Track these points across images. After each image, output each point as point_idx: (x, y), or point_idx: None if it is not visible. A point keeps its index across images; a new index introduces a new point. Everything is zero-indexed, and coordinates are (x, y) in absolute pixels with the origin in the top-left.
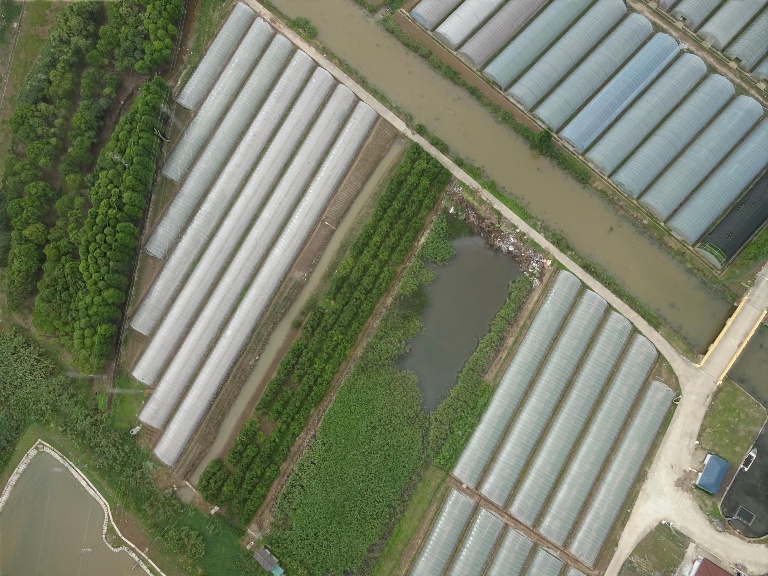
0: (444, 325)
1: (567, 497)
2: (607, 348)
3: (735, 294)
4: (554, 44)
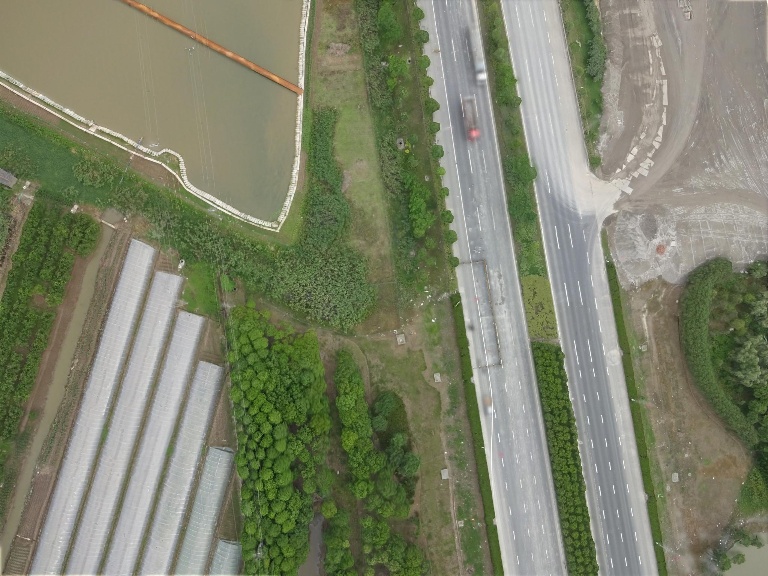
0: None
1: None
2: None
3: None
4: None
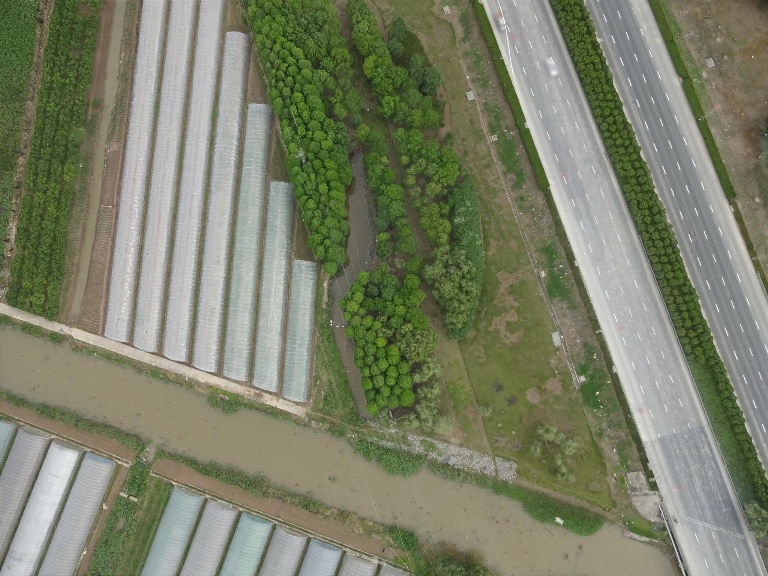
0: None
1: None
2: None
3: None
4: None
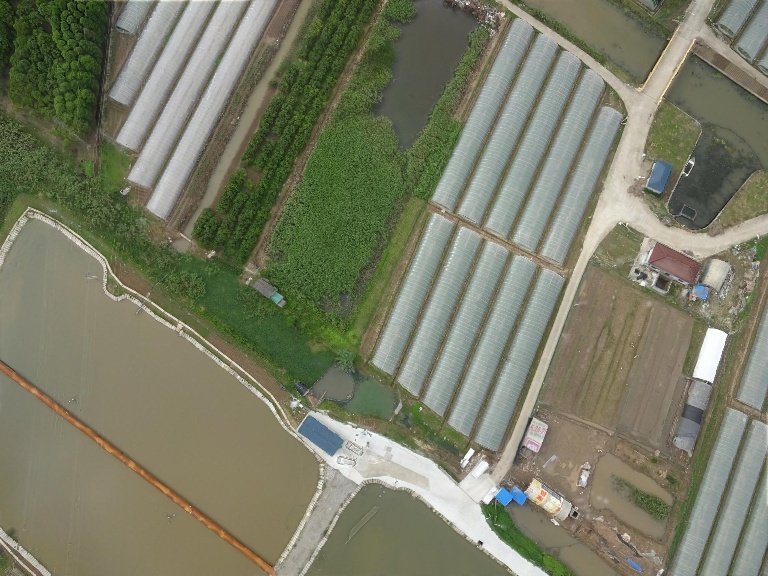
0: (412, 76)
1: (535, 209)
2: (560, 80)
3: (667, 30)
4: None
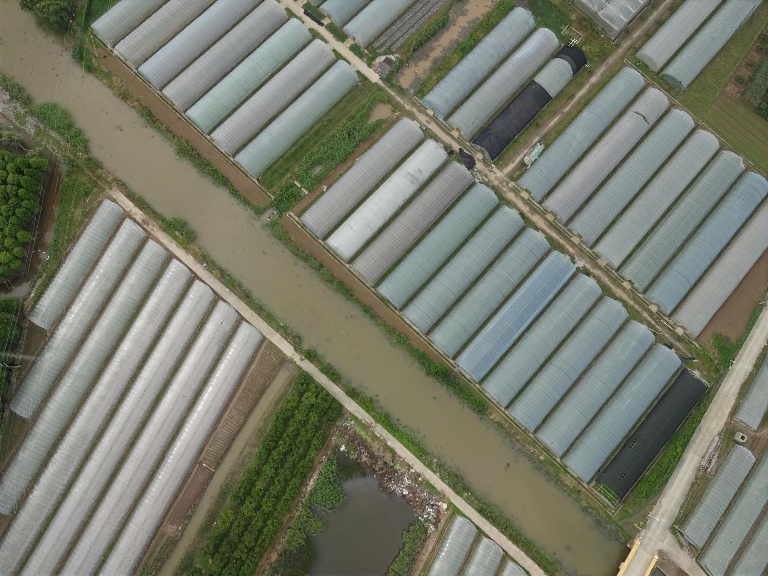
0: None
1: None
2: None
3: (628, 535)
4: (451, 259)
